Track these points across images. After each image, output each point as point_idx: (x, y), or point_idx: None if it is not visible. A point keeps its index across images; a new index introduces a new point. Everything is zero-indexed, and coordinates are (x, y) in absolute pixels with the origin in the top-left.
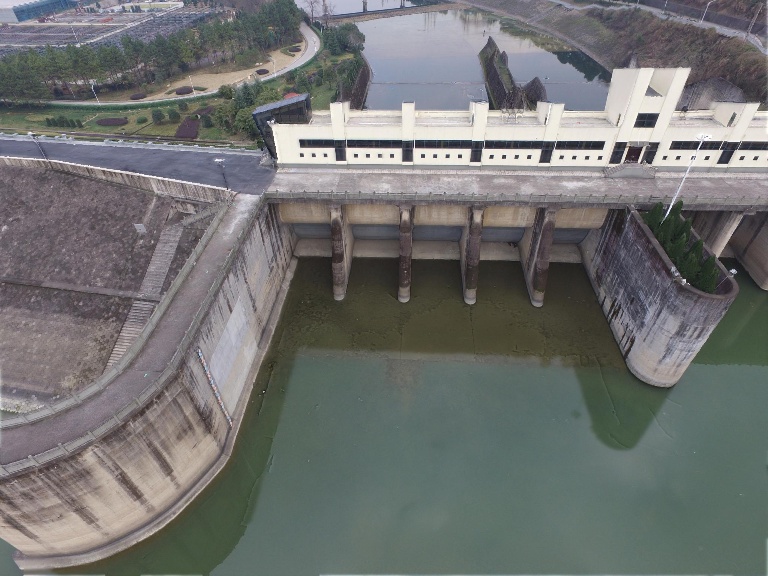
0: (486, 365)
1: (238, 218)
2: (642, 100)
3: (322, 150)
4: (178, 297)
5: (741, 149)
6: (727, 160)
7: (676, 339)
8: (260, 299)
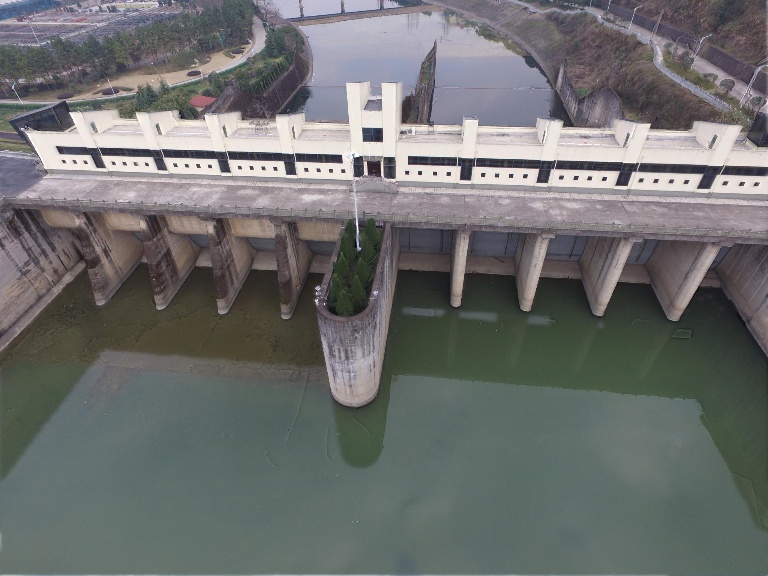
0: (197, 376)
1: None
2: (360, 114)
3: (81, 157)
4: None
5: (479, 166)
6: (469, 177)
7: (332, 359)
8: None
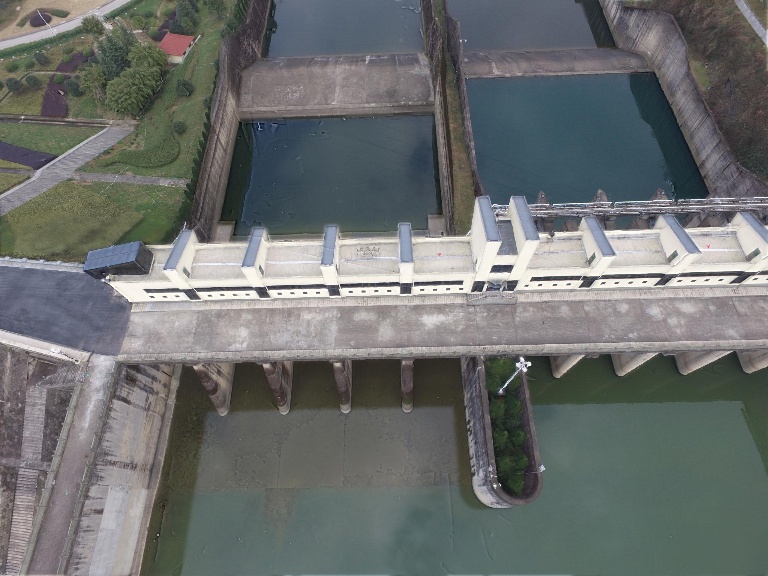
0: (352, 490)
1: (93, 401)
2: None
3: (172, 294)
4: (42, 535)
5: (602, 278)
6: (588, 285)
7: (496, 504)
8: (140, 450)
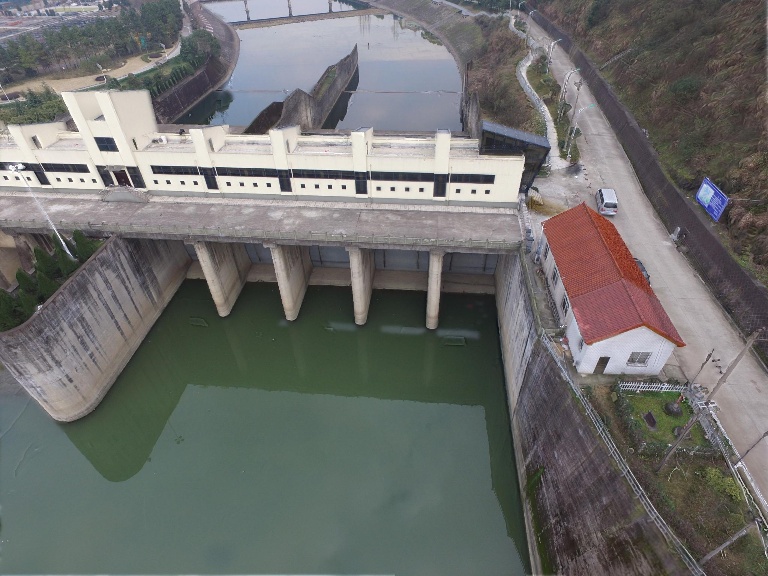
0: None
1: None
2: (86, 124)
3: None
4: None
5: (221, 175)
6: (215, 186)
7: None
8: None
